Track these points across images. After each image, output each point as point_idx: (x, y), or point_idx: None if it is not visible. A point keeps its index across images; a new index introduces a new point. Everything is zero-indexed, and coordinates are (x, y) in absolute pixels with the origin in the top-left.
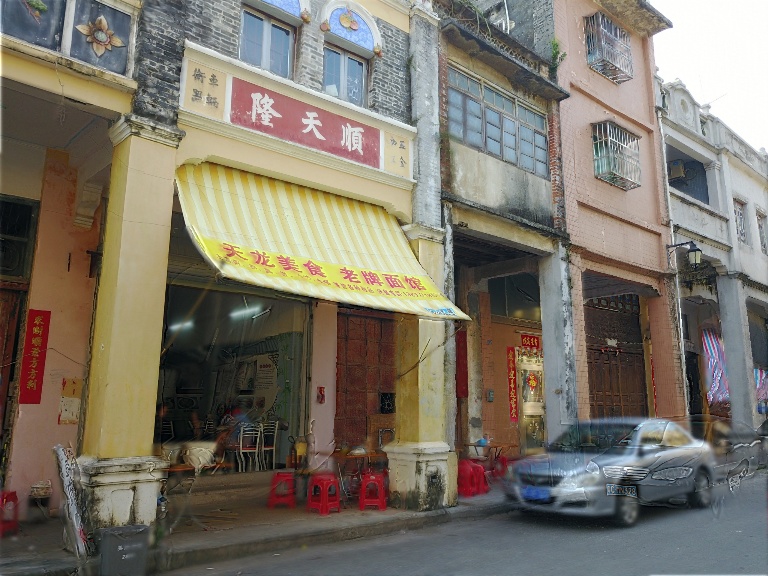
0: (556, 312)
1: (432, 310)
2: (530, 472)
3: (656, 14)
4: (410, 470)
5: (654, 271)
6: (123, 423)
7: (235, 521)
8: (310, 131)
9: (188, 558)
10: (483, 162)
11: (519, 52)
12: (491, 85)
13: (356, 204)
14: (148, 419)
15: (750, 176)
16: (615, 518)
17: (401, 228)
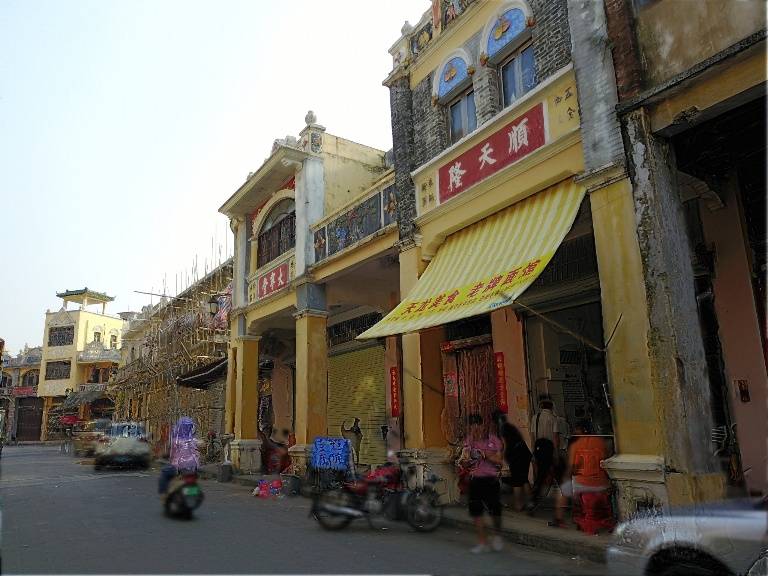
0: None
1: (494, 304)
2: None
3: None
4: None
5: None
6: (410, 427)
7: (520, 511)
8: (484, 164)
9: (424, 517)
10: None
11: None
12: None
13: (550, 191)
14: None
15: None
16: None
17: None
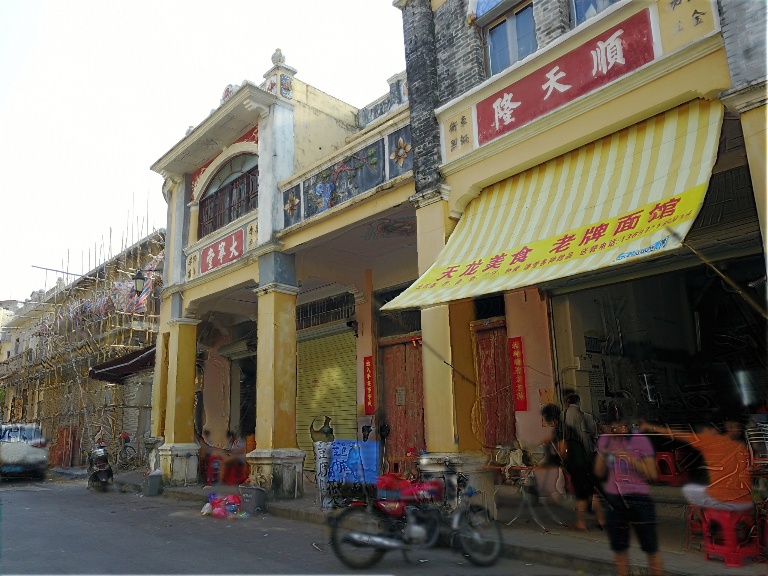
0: None
1: (629, 253)
2: None
3: None
4: None
5: None
6: (435, 426)
7: (590, 531)
8: (552, 92)
9: (466, 543)
10: None
11: None
12: None
13: (651, 123)
14: (449, 423)
15: None
16: None
17: (725, 112)
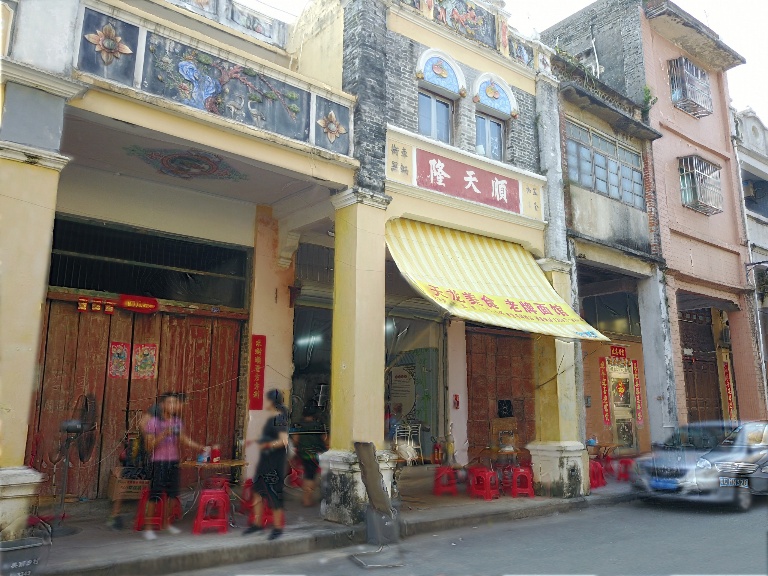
0: (656, 328)
1: (579, 333)
2: (637, 469)
3: (732, 53)
4: (553, 464)
5: (735, 288)
6: (366, 425)
7: (424, 503)
8: (470, 187)
9: (417, 528)
10: (594, 200)
11: (617, 99)
12: (597, 132)
13: (501, 243)
14: (380, 422)
15: None
16: (728, 506)
17: (536, 262)
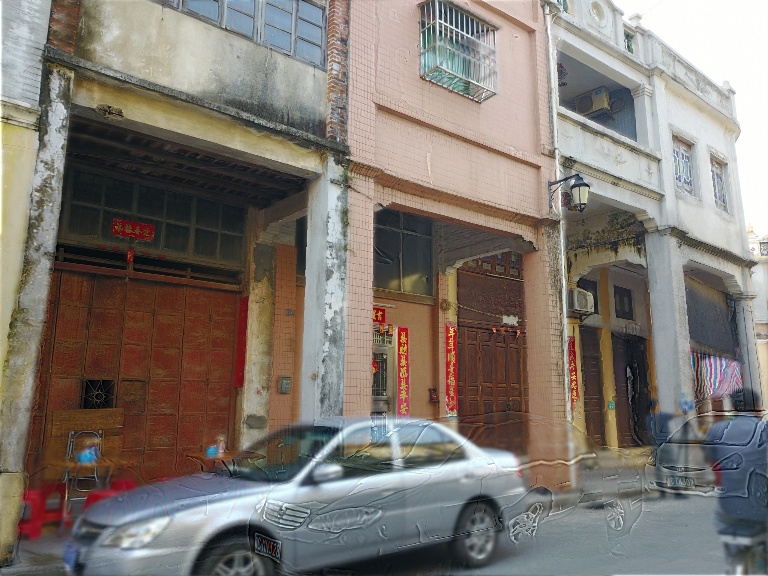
0: (319, 259)
1: None
2: (262, 498)
3: None
4: None
5: (523, 215)
6: None
7: None
8: None
9: None
10: (172, 23)
11: None
12: None
13: None
14: None
15: (701, 110)
16: None
17: None
